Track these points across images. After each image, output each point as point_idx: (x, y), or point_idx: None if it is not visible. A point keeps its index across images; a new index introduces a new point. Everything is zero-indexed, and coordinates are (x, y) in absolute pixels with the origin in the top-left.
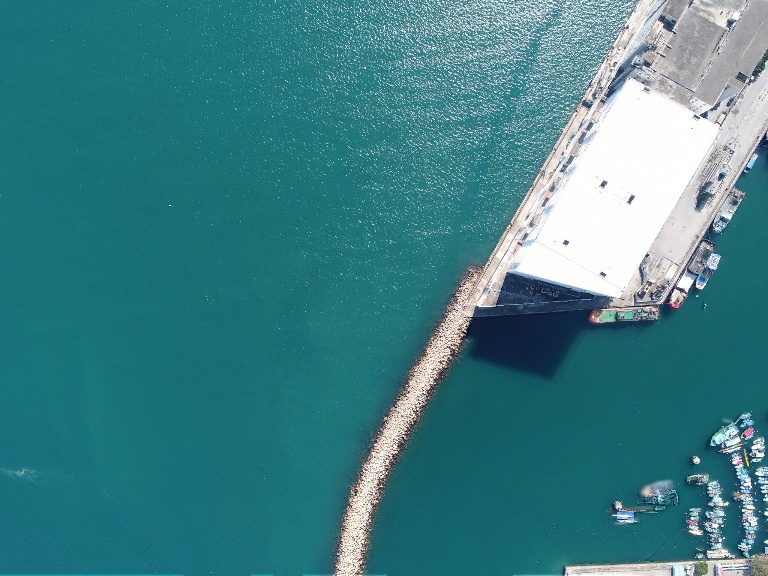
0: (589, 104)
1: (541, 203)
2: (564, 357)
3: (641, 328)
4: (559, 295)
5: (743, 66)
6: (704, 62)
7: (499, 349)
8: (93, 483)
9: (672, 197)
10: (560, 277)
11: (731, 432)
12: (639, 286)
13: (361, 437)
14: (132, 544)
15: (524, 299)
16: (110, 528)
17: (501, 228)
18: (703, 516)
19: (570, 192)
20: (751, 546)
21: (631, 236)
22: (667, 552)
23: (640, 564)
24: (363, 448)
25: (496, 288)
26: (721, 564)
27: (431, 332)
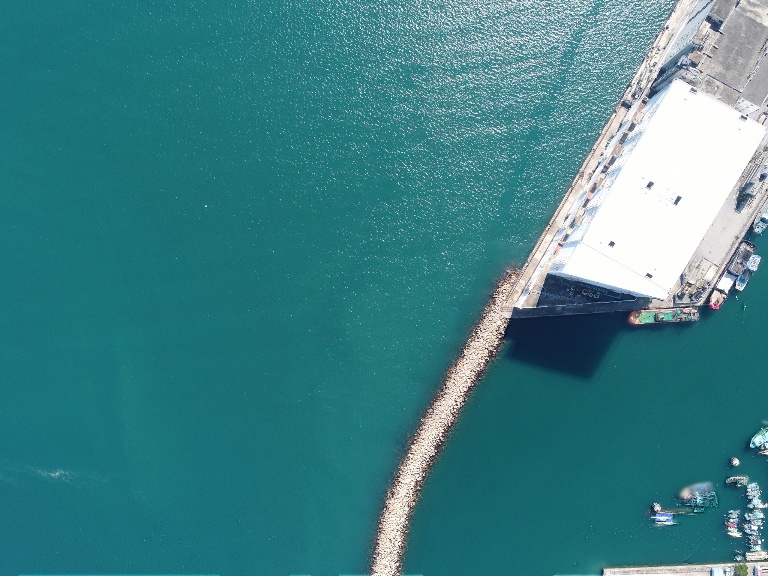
0: (628, 105)
1: (582, 204)
2: (602, 358)
3: (680, 329)
4: (600, 296)
5: None
6: (751, 62)
7: (537, 350)
8: (128, 485)
9: (719, 198)
10: (606, 278)
11: None
12: (678, 287)
13: (398, 439)
14: (170, 546)
15: (564, 300)
16: (148, 530)
17: (539, 229)
18: (742, 518)
19: (616, 193)
20: None
21: (677, 237)
22: (706, 554)
23: (679, 566)
24: (400, 450)
25: (536, 289)
26: (760, 566)
27: (468, 333)
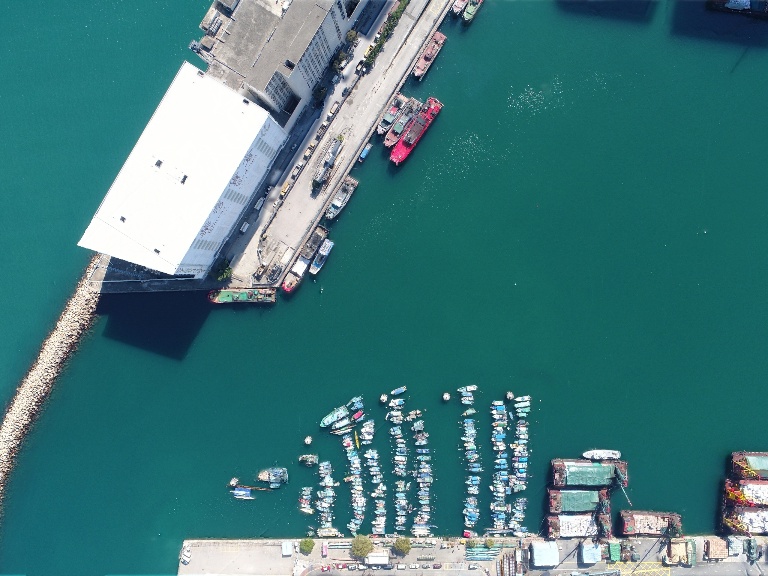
0: None
1: None
2: (189, 335)
3: (262, 310)
4: (162, 273)
5: (291, 54)
6: (260, 49)
7: (127, 325)
8: None
9: (222, 178)
10: (118, 252)
11: (339, 414)
12: (257, 268)
13: None
14: None
15: (129, 276)
16: None
17: None
18: (315, 495)
19: (130, 170)
20: (360, 526)
21: (183, 215)
22: (282, 529)
23: (254, 540)
24: None
25: (104, 264)
26: (328, 542)
27: (64, 306)
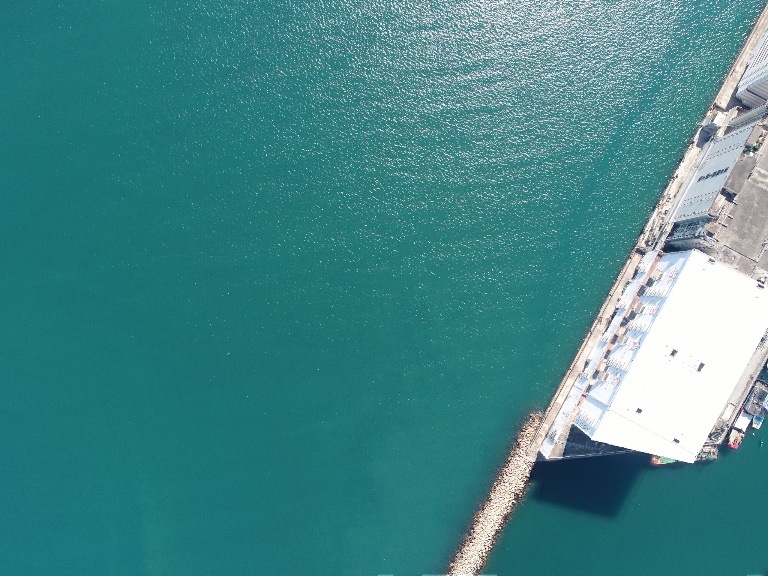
0: (642, 251)
1: (603, 355)
2: (626, 497)
3: (700, 466)
4: None
5: None
6: (764, 231)
7: (562, 491)
8: None
9: (740, 364)
10: (634, 444)
11: None
12: None
13: None
14: None
15: (590, 450)
16: None
17: (560, 373)
18: None
19: (641, 360)
20: None
21: (702, 403)
22: None
23: None
24: None
25: (562, 440)
26: None
27: (494, 476)
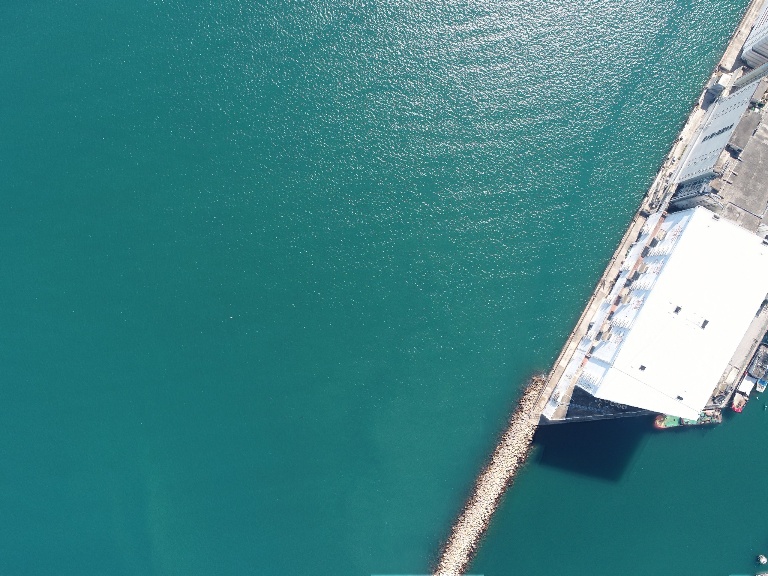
0: (646, 214)
1: (607, 317)
2: (629, 461)
3: (704, 430)
4: (627, 407)
5: None
6: None
7: (565, 455)
8: None
9: (745, 321)
10: (638, 402)
11: None
12: None
13: (430, 547)
14: None
15: (593, 411)
16: None
17: (564, 336)
18: None
19: (644, 318)
20: None
21: (706, 360)
22: None
23: None
24: (432, 558)
25: (565, 401)
26: None
27: (497, 440)
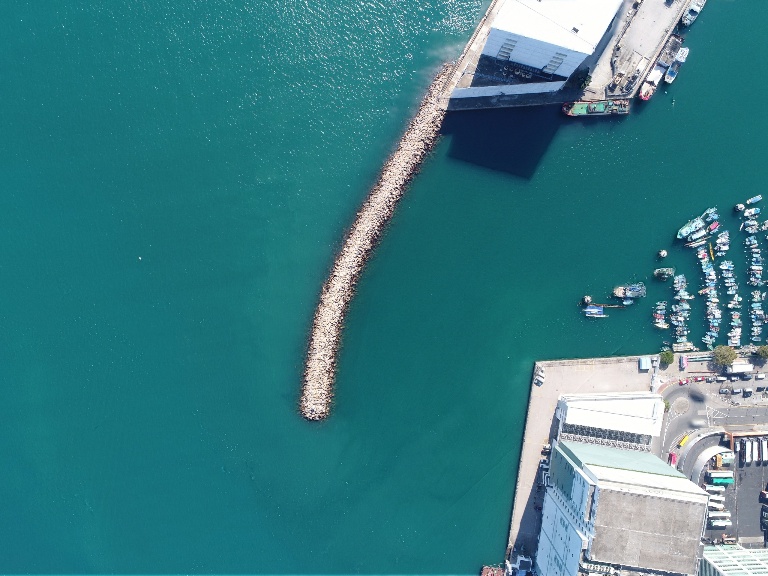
0: None
1: None
2: (536, 152)
3: (612, 124)
4: (532, 77)
5: None
6: None
7: (472, 144)
8: (57, 281)
9: None
10: (533, 33)
11: (697, 224)
12: (610, 80)
13: (334, 234)
14: (97, 329)
15: (498, 81)
16: (75, 313)
17: (476, 21)
18: (669, 310)
19: None
20: (715, 339)
21: None
22: (634, 347)
23: (608, 358)
24: (336, 245)
25: (470, 70)
26: (686, 355)
27: (405, 127)
